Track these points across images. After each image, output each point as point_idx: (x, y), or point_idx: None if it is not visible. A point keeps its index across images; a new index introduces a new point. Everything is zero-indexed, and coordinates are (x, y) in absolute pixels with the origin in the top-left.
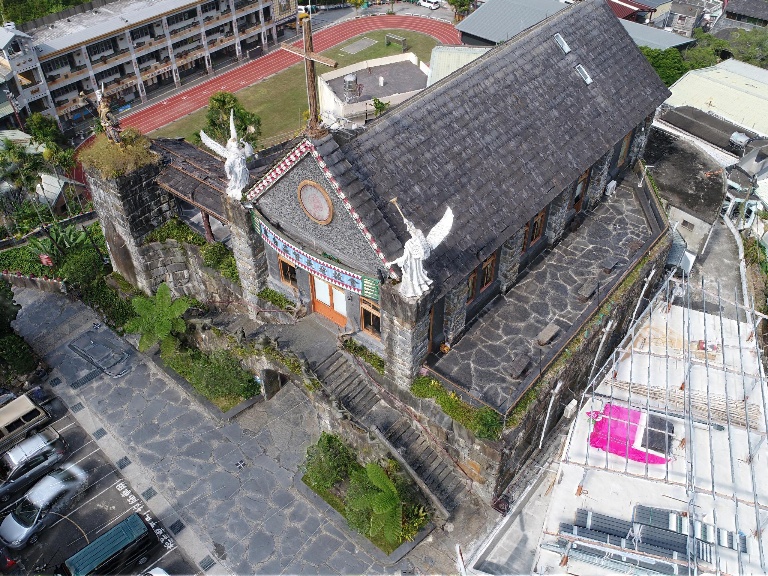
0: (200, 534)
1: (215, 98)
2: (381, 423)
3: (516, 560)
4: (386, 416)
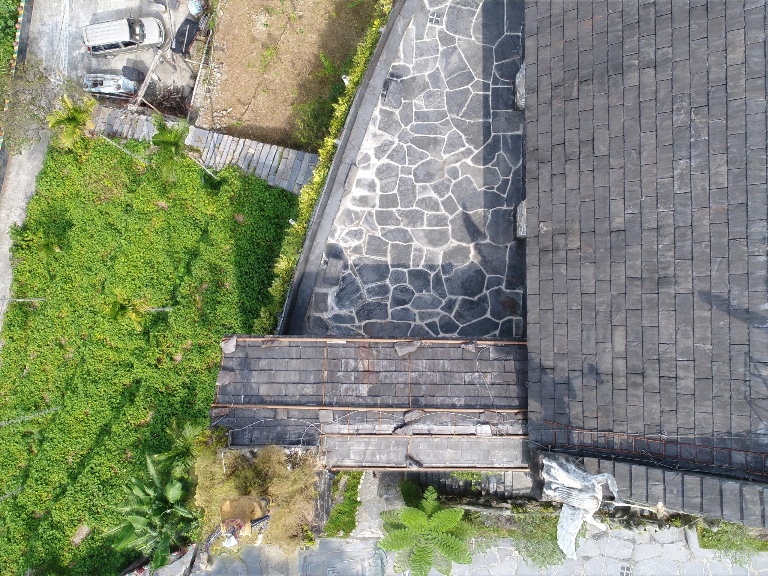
0: None
1: (56, 119)
2: None
3: None
4: None
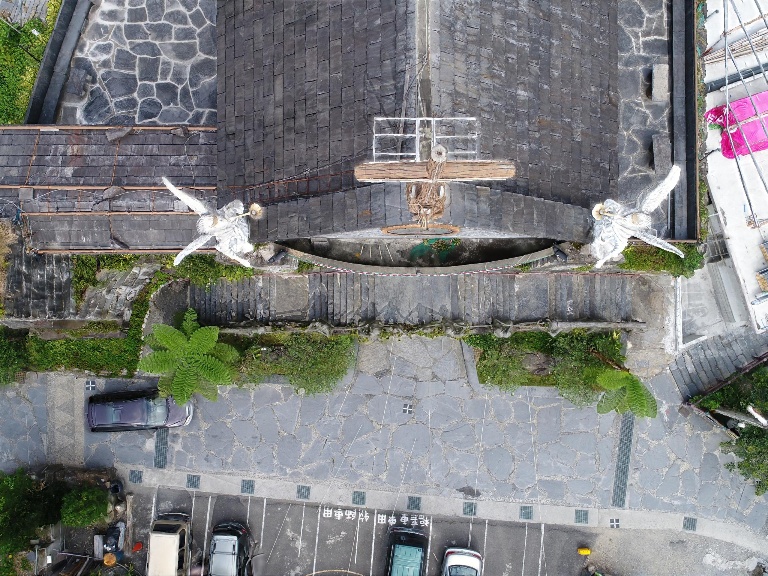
0: (439, 493)
1: None
2: (537, 299)
3: (695, 296)
4: (535, 288)
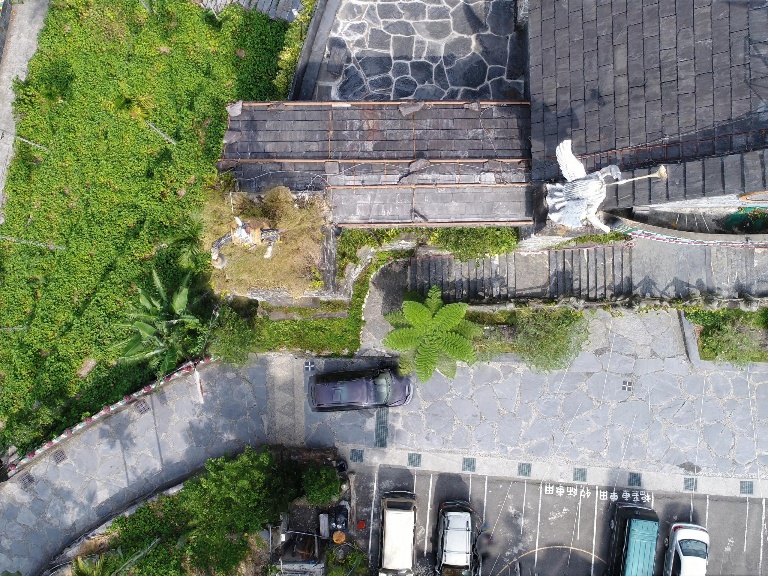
0: (660, 469)
1: None
2: None
3: None
4: None
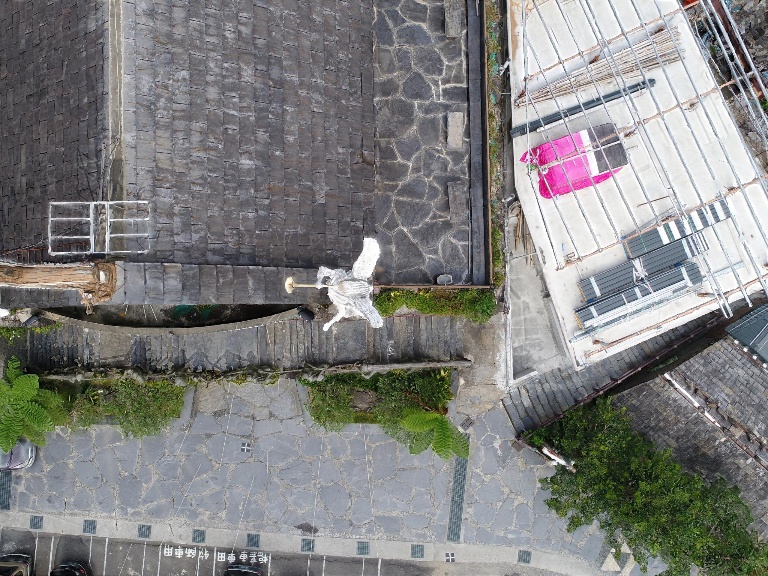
0: (277, 530)
1: None
2: (355, 342)
3: (532, 331)
4: (353, 330)
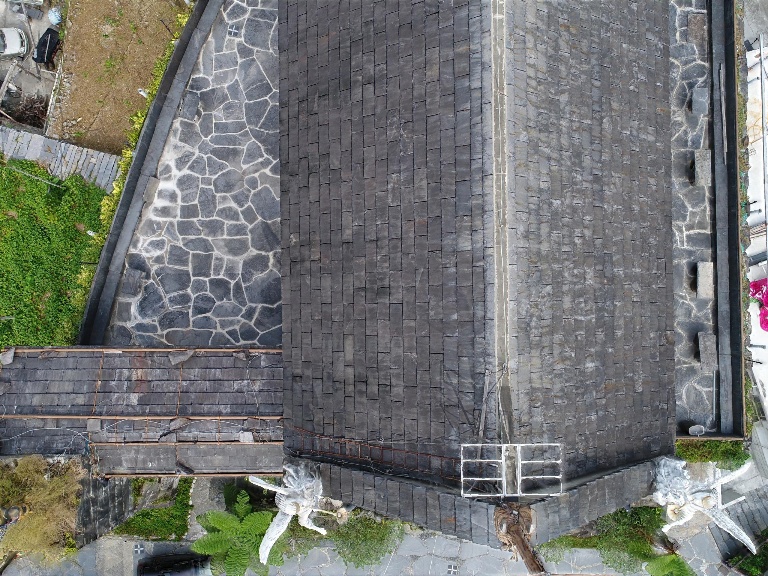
0: None
1: None
2: None
3: None
4: None
